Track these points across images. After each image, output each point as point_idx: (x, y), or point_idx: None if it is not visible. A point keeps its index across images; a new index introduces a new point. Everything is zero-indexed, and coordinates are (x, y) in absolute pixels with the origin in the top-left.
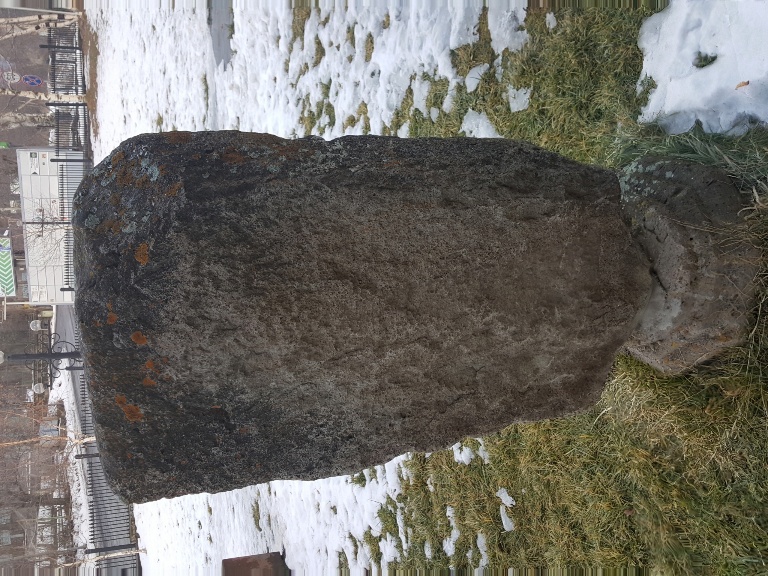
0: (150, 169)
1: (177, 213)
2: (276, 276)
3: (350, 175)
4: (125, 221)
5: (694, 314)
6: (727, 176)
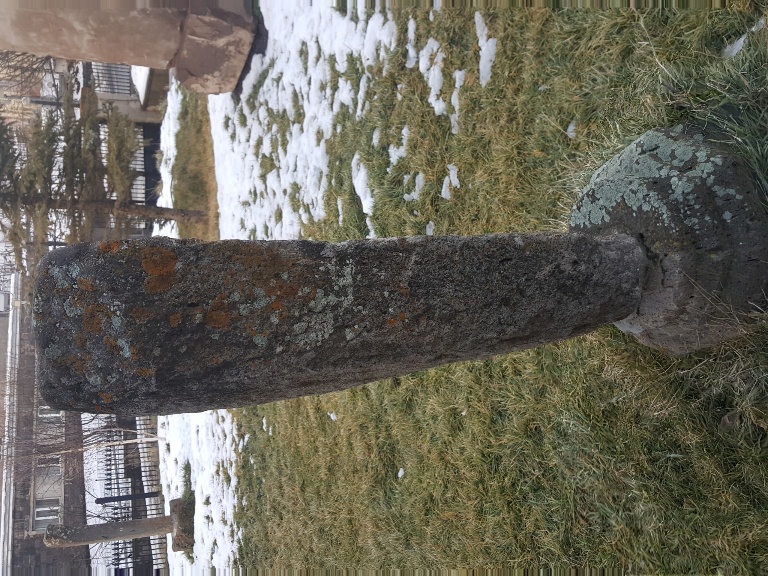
0: (120, 343)
1: (145, 392)
2: (240, 394)
3: (343, 346)
4: (89, 368)
5: (650, 332)
6: None
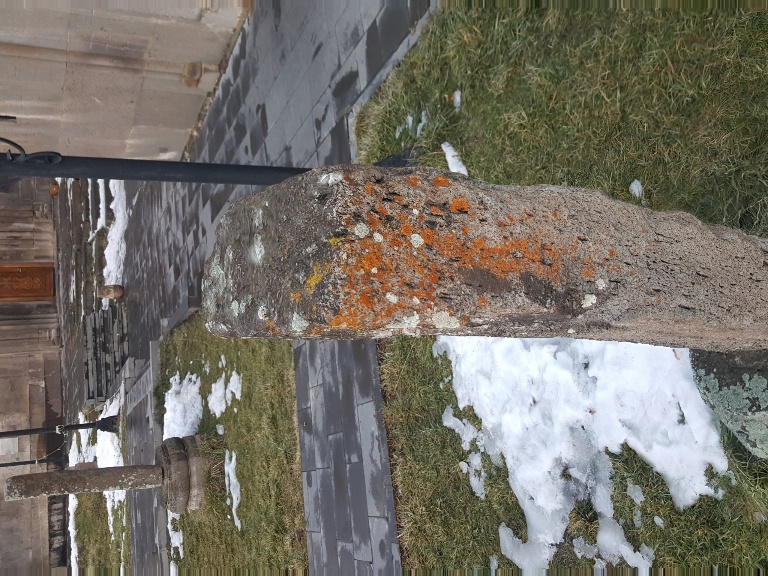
0: None
1: None
2: None
3: None
4: None
5: None
6: None
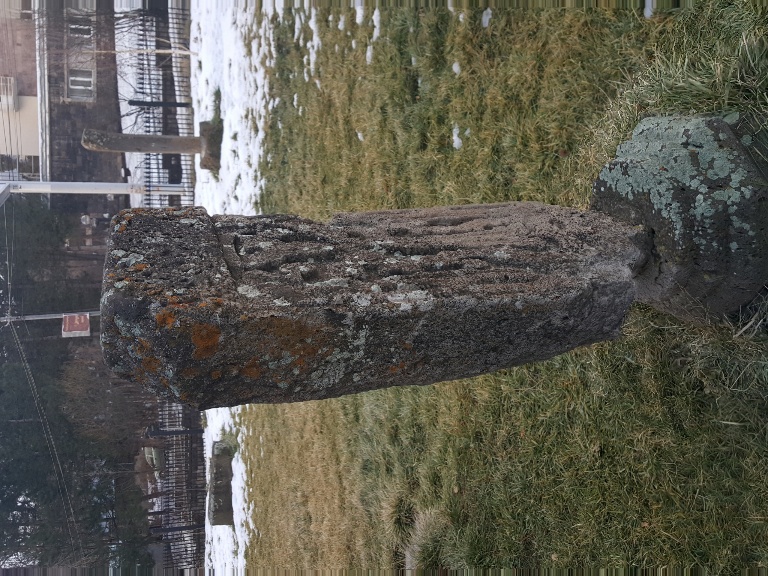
0: (172, 388)
1: None
2: None
3: None
4: None
5: None
6: (763, 285)
